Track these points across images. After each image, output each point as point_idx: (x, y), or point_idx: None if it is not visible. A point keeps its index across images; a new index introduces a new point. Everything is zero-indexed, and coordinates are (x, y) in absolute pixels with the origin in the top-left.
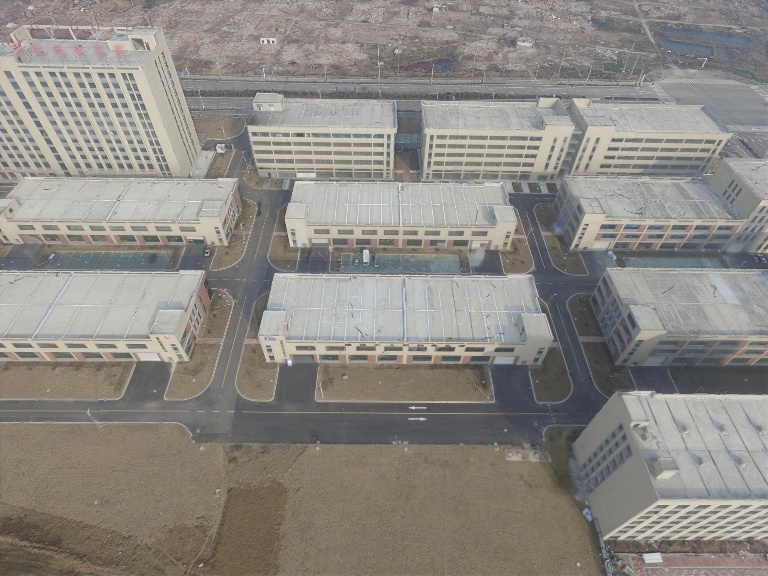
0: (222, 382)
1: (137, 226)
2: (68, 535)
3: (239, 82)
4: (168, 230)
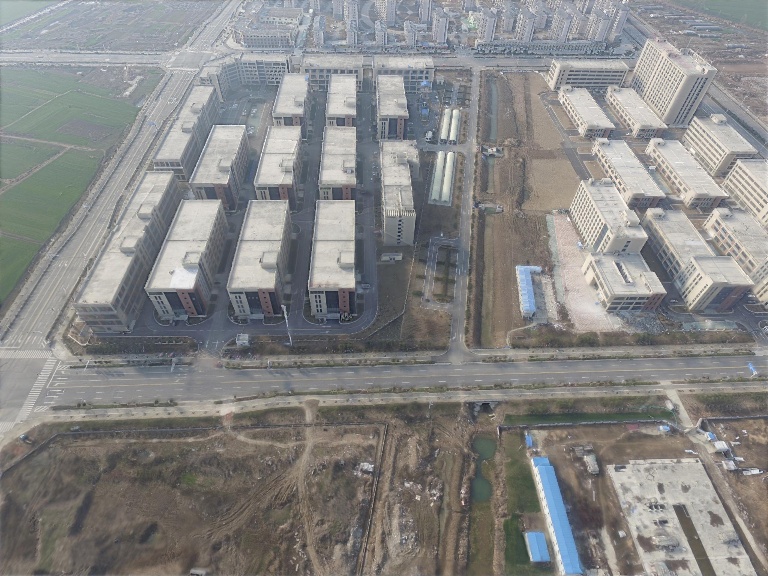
0: None
1: None
2: (530, 131)
3: (759, 126)
4: (630, 121)
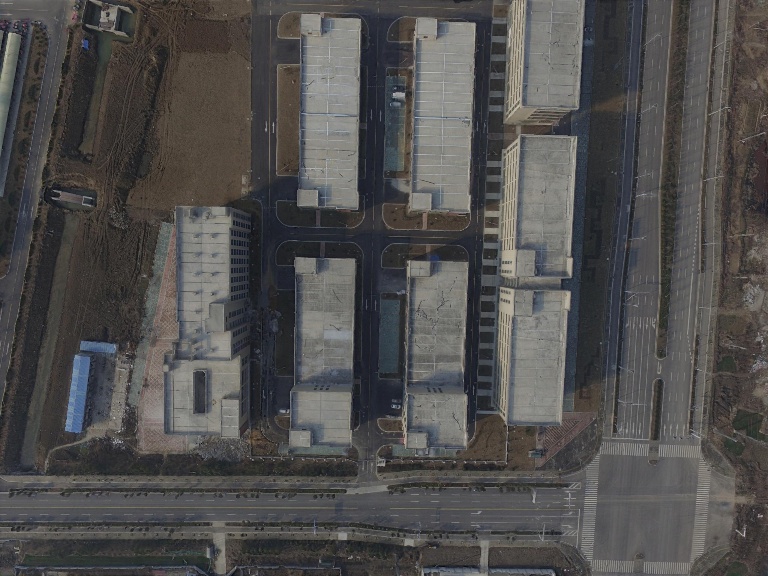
0: (291, 3)
1: None
2: None
3: None
4: None
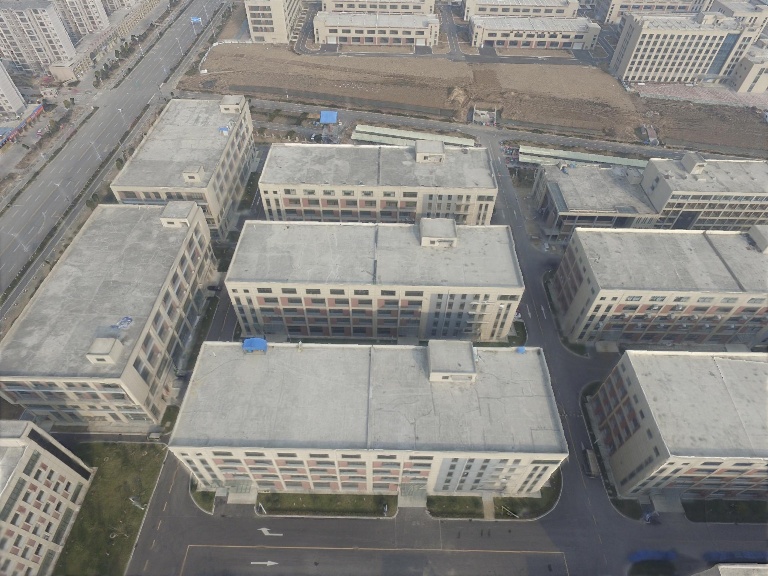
0: None
1: (393, 5)
2: (417, 78)
3: None
4: (407, 8)
